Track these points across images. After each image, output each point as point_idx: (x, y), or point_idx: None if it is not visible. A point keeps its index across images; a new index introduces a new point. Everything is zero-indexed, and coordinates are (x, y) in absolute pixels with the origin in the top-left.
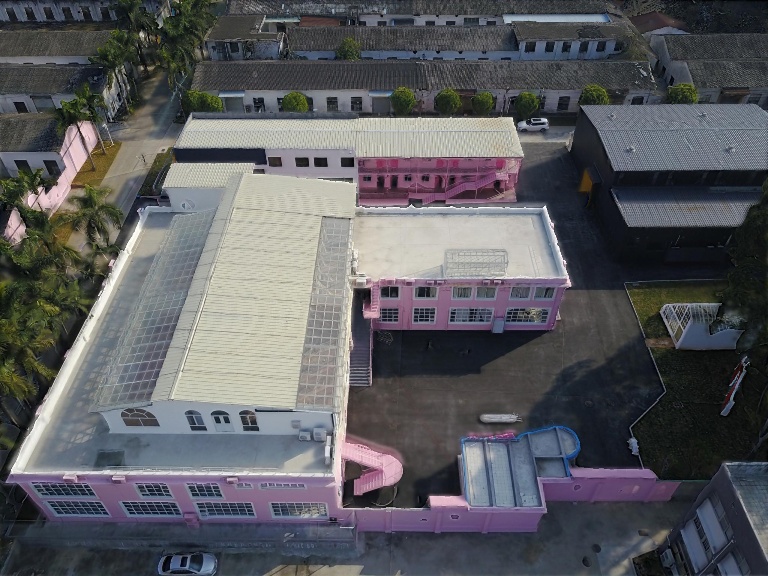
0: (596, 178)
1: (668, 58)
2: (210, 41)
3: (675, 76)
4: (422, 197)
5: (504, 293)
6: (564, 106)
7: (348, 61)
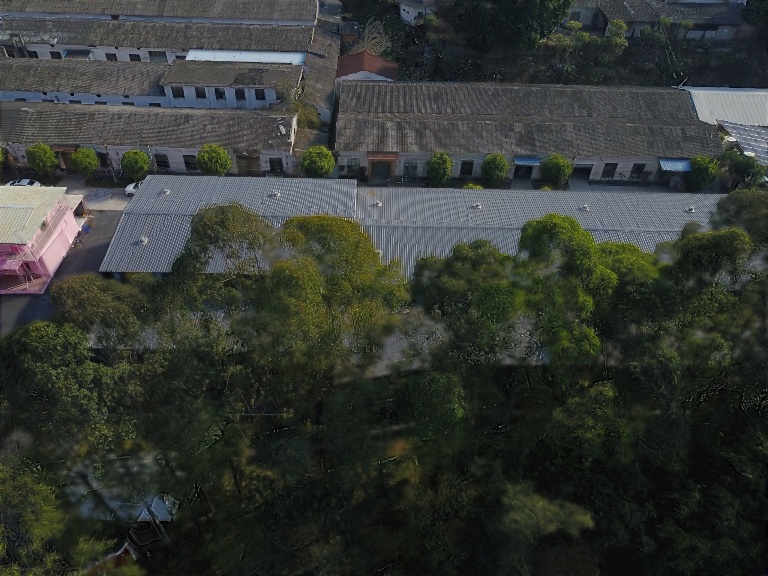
0: None
1: None
2: None
3: None
4: None
5: None
6: (193, 165)
7: None
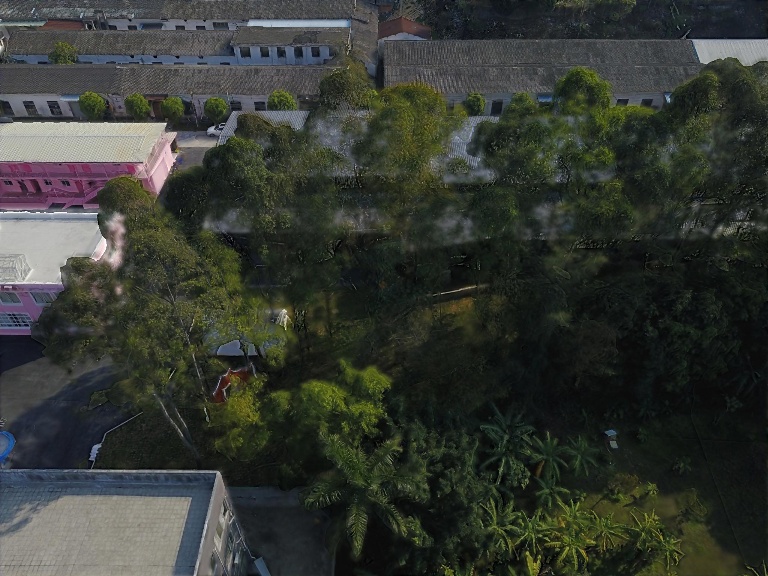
0: None
1: None
2: None
3: None
4: (65, 201)
5: (26, 298)
6: None
7: (56, 65)
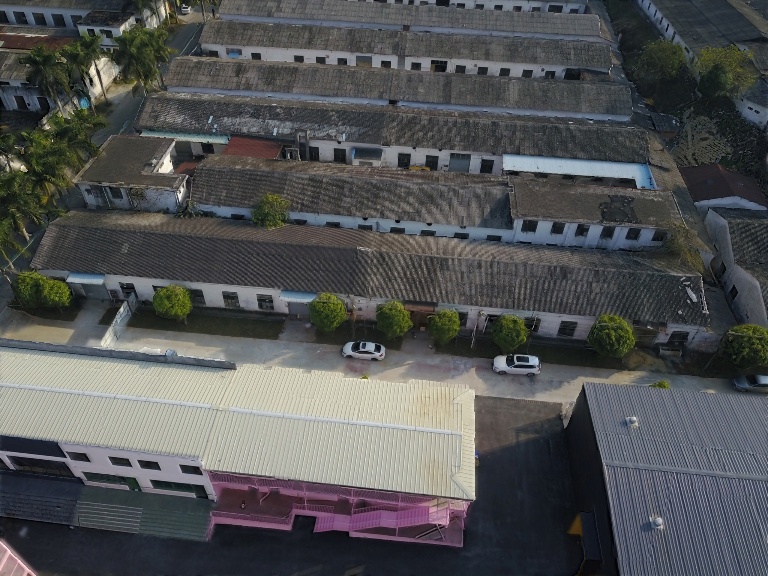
0: (593, 546)
1: (731, 257)
2: (81, 184)
3: (739, 289)
4: (316, 515)
5: None
6: (568, 331)
7: (264, 231)
